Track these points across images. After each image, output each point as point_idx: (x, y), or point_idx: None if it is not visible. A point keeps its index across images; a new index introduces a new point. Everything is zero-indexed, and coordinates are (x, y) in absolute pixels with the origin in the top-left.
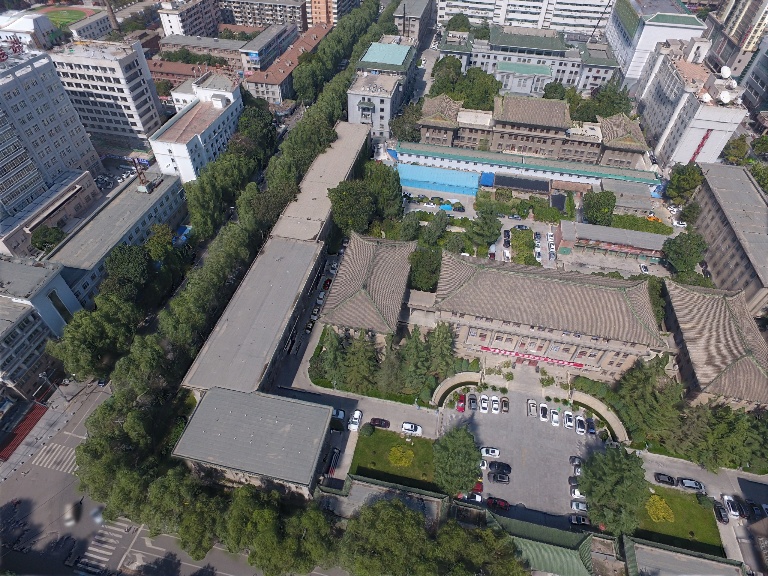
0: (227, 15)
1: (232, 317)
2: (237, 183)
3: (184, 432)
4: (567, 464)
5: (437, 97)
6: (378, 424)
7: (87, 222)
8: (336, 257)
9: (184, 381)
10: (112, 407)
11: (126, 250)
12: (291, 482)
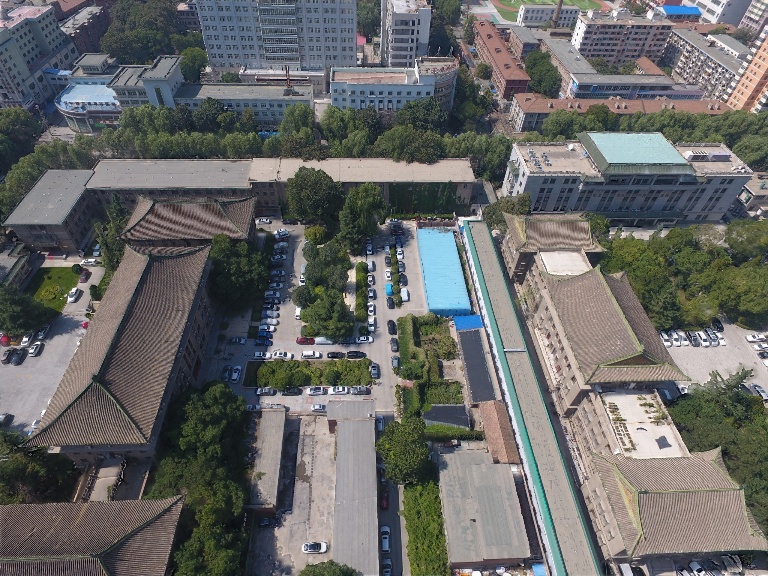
0: (675, 55)
1: (159, 164)
2: (336, 134)
3: (62, 170)
4: (7, 412)
5: (583, 219)
6: (82, 274)
7: (244, 84)
8: (280, 221)
9: (103, 160)
10: (81, 139)
11: (211, 103)
12: (7, 216)
